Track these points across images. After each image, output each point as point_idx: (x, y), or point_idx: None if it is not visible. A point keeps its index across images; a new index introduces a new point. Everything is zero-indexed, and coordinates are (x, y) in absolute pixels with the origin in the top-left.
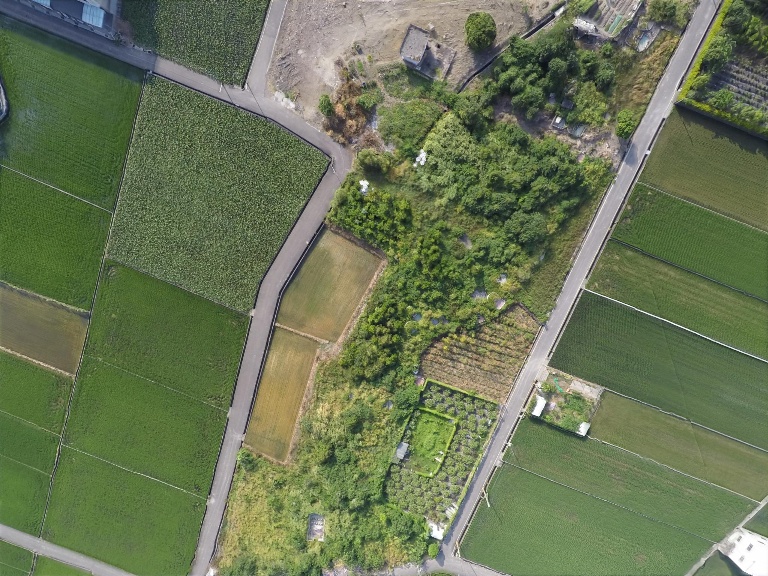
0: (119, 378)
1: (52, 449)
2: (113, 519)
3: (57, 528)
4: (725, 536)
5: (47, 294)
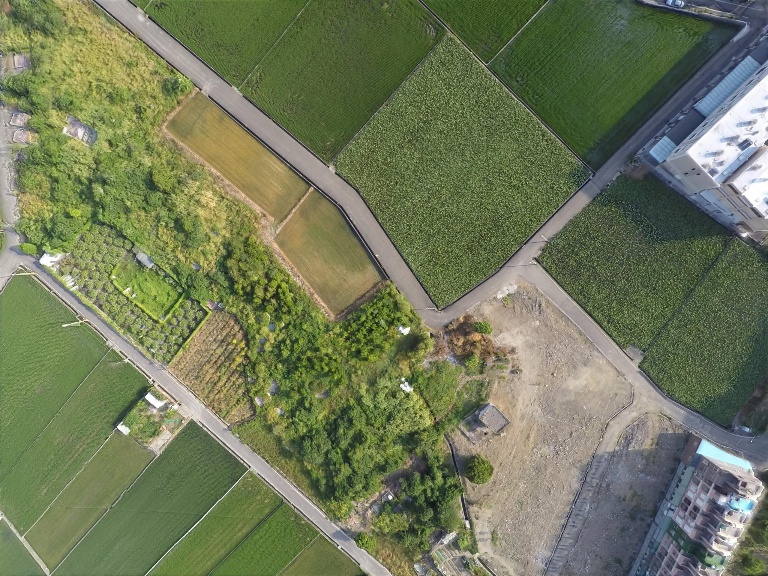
0: None
1: None
2: None
3: None
4: None
5: None
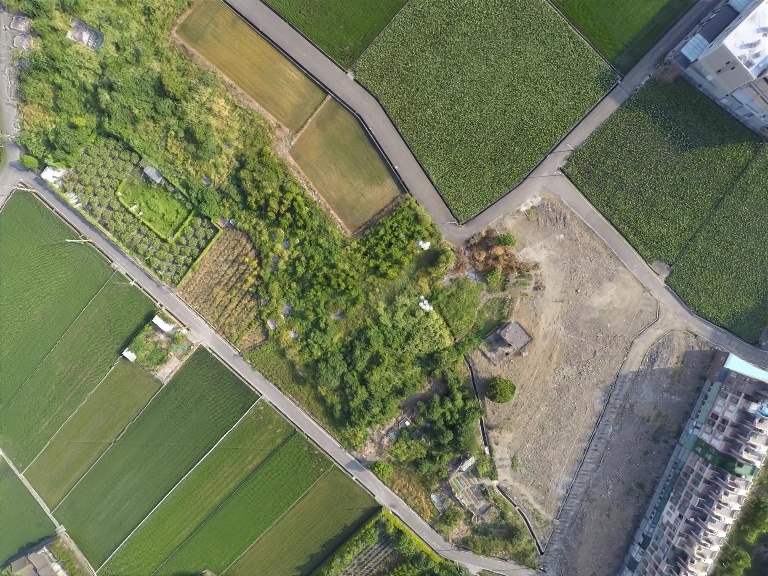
0: None
1: None
2: None
3: None
4: None
5: None
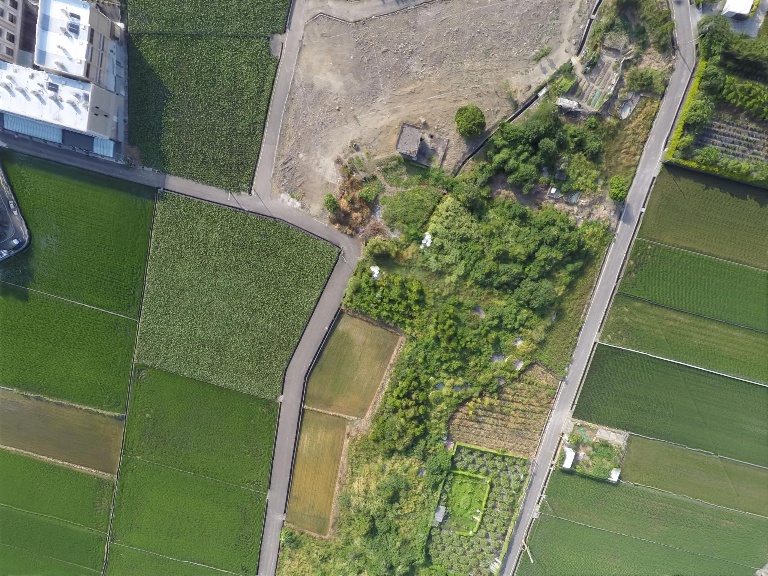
0: (158, 473)
1: (100, 547)
2: None
3: None
4: (767, 561)
5: (82, 403)
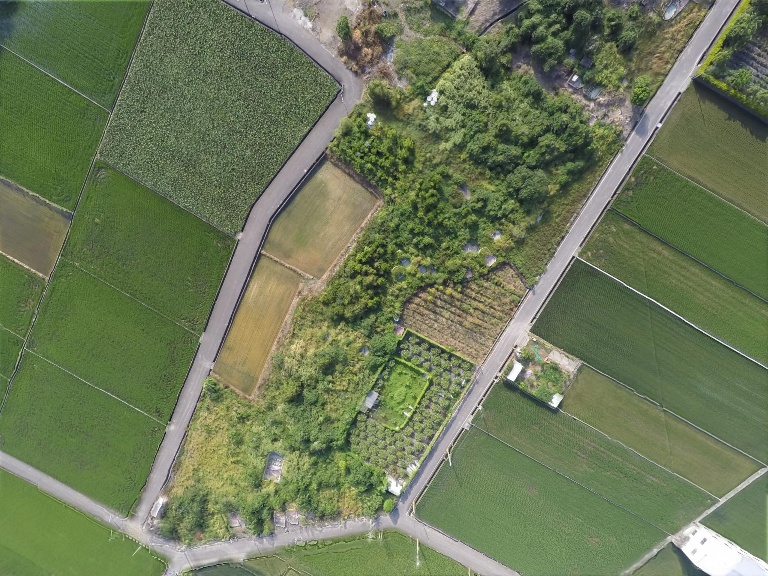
0: (94, 287)
1: (14, 352)
2: (67, 434)
3: (8, 435)
4: (681, 529)
5: (31, 188)
